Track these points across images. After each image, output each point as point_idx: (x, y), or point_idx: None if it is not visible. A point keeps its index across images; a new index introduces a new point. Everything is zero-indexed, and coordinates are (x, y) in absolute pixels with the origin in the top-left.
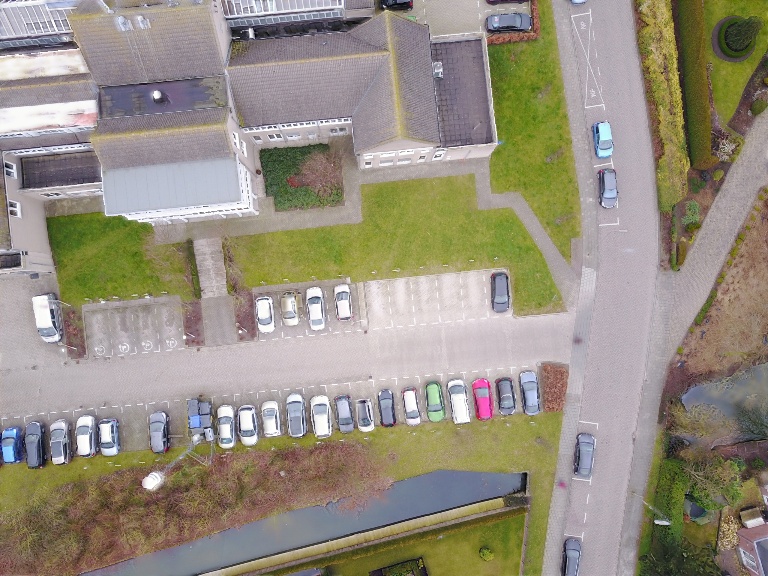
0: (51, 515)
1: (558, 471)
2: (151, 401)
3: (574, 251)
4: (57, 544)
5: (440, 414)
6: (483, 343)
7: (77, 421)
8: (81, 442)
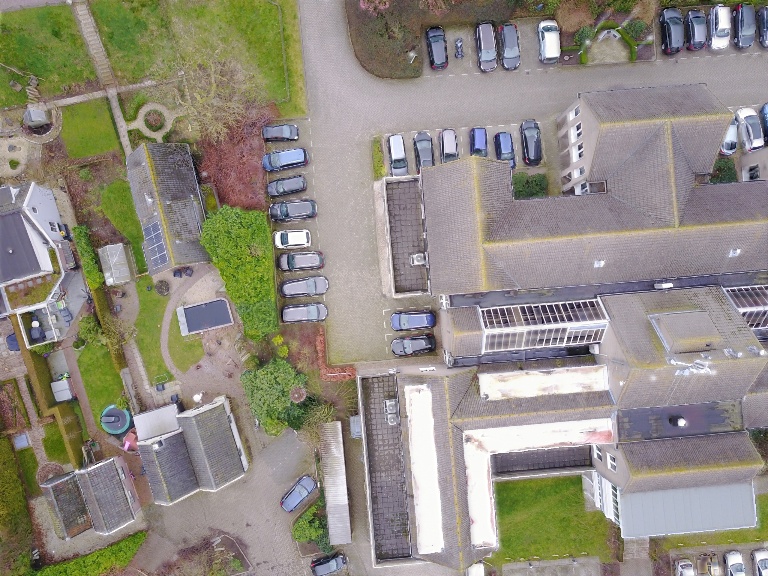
0: None
1: None
2: None
3: None
4: None
5: None
6: None
7: None
8: None
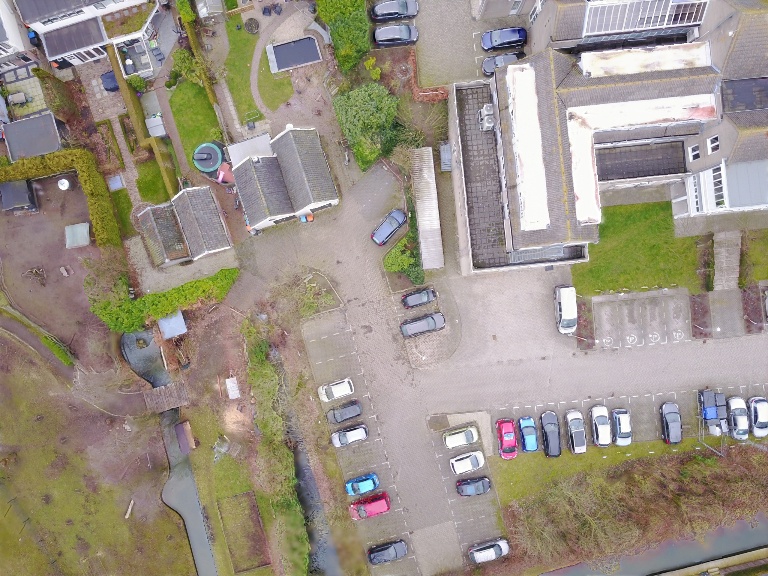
0: (615, 503)
1: None
2: (658, 392)
3: None
4: (623, 531)
5: None
6: None
7: (593, 411)
8: (603, 431)
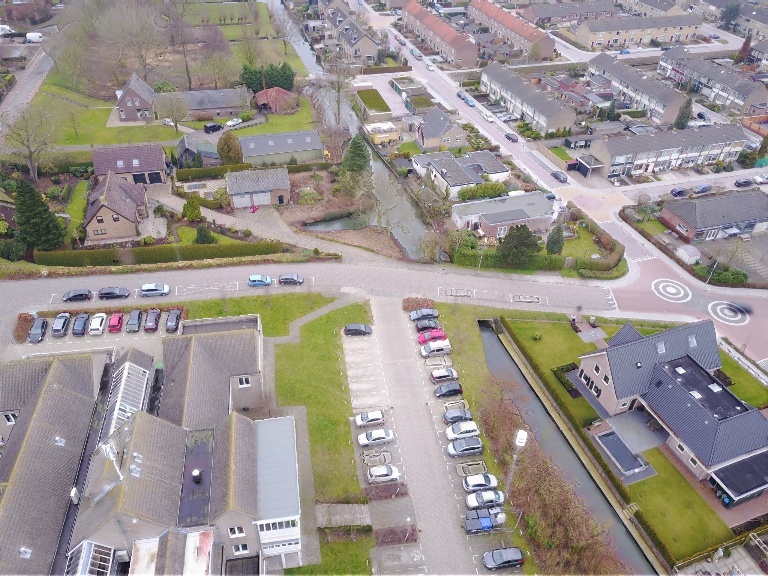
0: None
1: (472, 304)
2: (475, 573)
3: (330, 295)
4: None
5: (446, 359)
6: (394, 340)
7: None
8: None
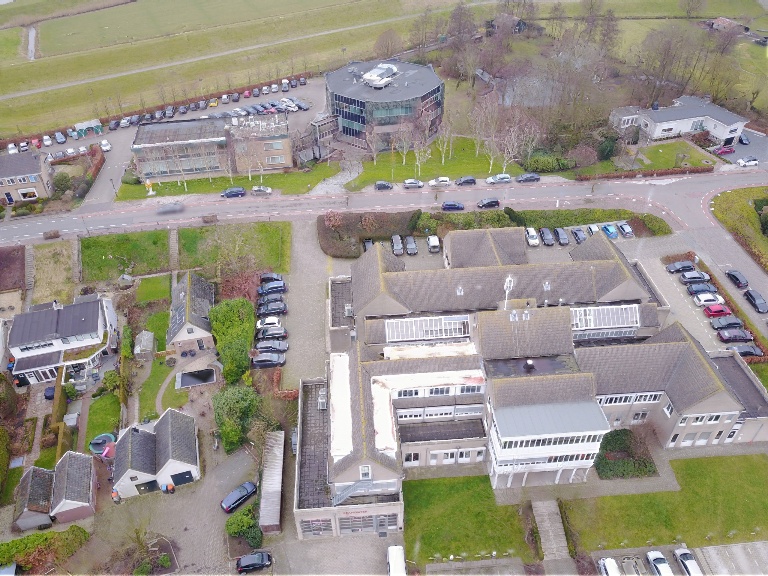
0: None
1: None
2: None
3: None
4: None
5: None
6: None
7: None
8: None
